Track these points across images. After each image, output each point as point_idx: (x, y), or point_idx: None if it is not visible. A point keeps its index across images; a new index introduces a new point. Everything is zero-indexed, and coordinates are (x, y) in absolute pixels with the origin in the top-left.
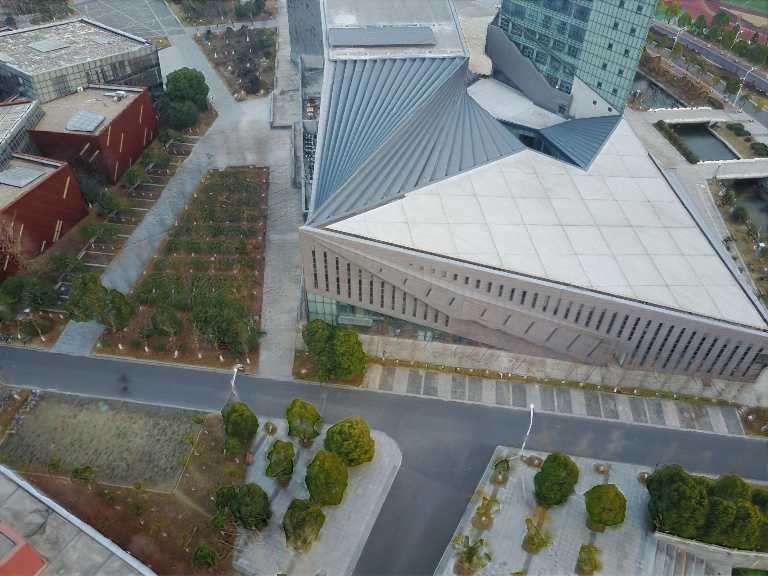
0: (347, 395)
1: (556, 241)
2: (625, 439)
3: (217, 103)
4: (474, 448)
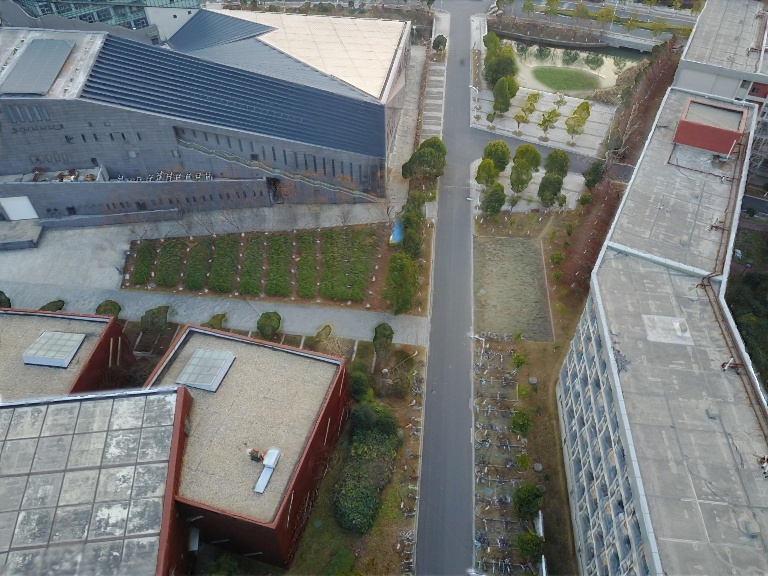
0: (445, 178)
1: (359, 46)
2: (456, 91)
3: None
4: (474, 133)
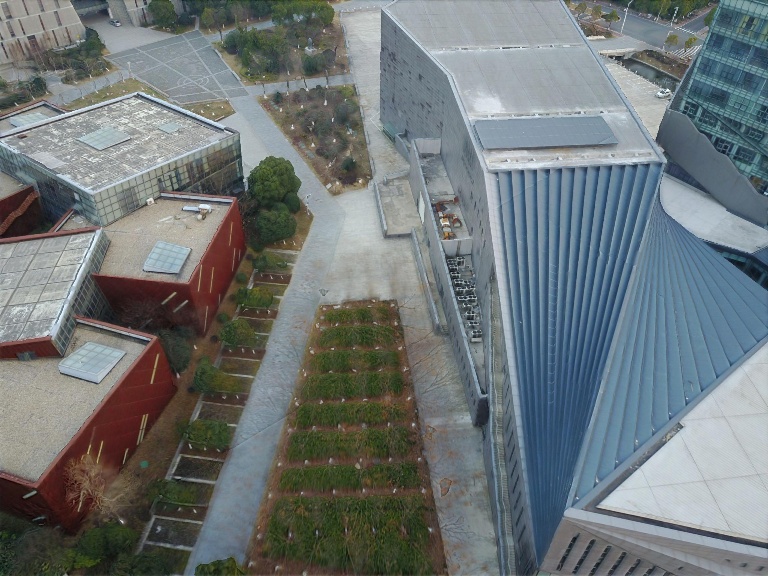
0: None
1: None
2: None
3: (308, 198)
4: None
